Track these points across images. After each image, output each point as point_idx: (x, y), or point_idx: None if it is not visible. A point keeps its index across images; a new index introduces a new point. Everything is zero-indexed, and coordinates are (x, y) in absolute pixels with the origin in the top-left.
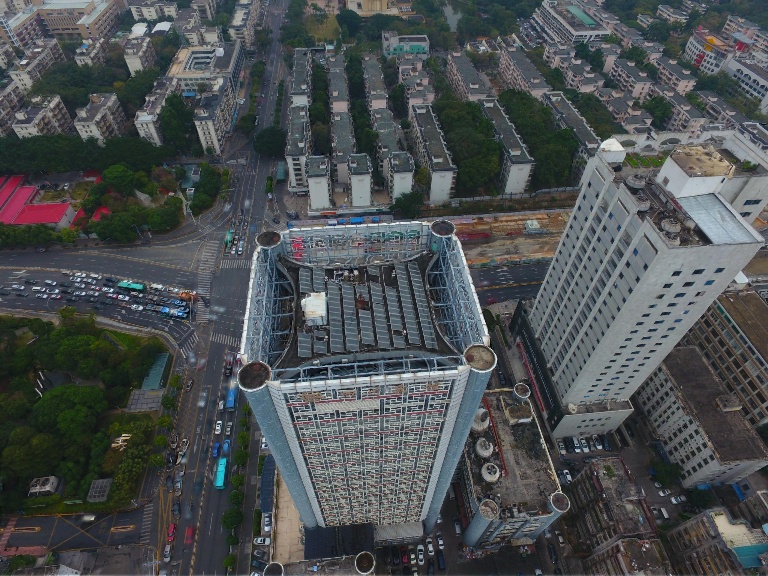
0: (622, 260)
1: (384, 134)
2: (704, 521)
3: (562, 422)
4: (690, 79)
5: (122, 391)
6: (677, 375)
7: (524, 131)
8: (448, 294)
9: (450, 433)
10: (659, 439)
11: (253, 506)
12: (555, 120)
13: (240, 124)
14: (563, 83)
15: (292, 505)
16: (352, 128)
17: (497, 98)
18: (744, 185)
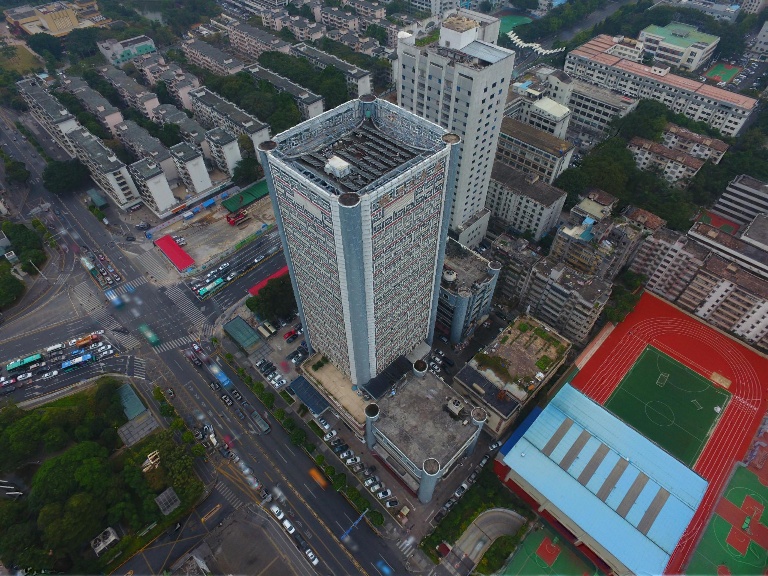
0: (452, 100)
1: (182, 124)
2: (560, 236)
3: (459, 241)
4: (381, 8)
5: (113, 430)
6: (500, 179)
7: (299, 79)
8: (397, 133)
9: (442, 217)
10: (510, 225)
11: (304, 424)
12: (313, 65)
13: (11, 175)
14: (295, 39)
15: (340, 387)
16: (146, 130)
17: (257, 63)
18: (484, 33)
